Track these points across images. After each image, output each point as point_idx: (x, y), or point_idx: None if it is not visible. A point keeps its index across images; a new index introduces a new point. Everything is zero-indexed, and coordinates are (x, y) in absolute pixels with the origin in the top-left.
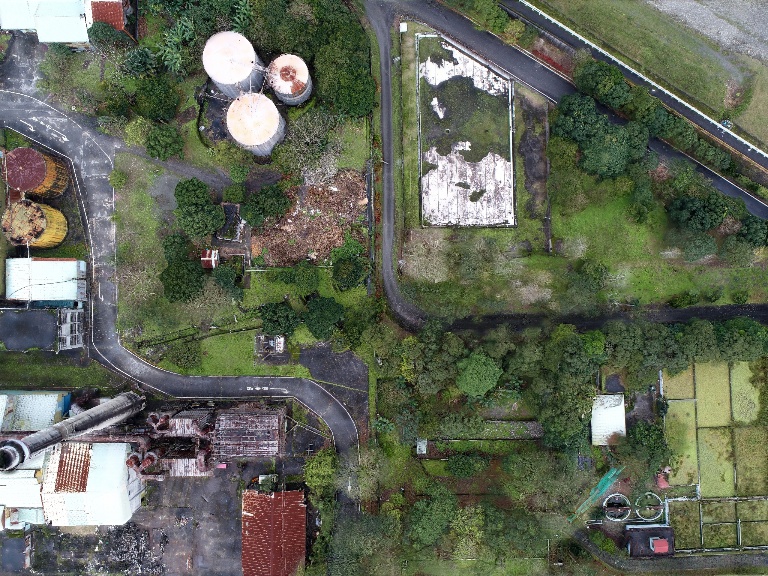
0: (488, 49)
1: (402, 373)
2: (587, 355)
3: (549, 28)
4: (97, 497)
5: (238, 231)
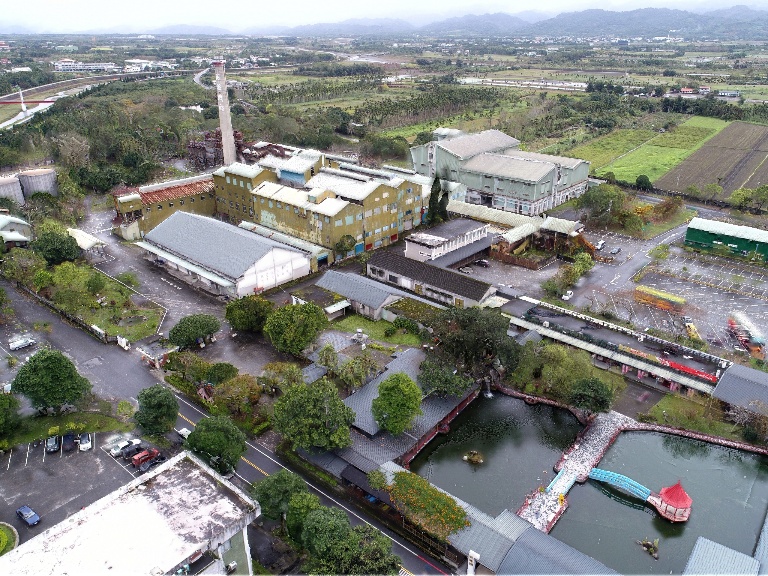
0: None
1: None
2: None
3: None
4: None
5: None
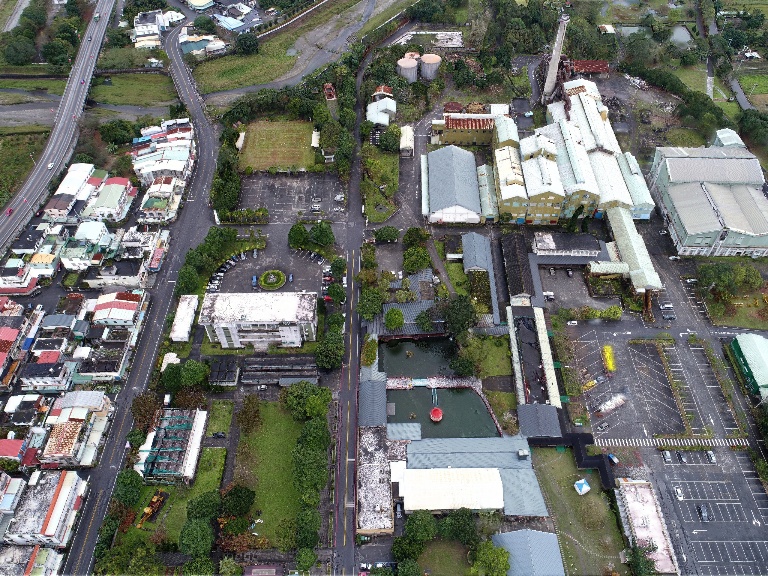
0: None
1: None
2: None
3: None
4: (585, 83)
5: None
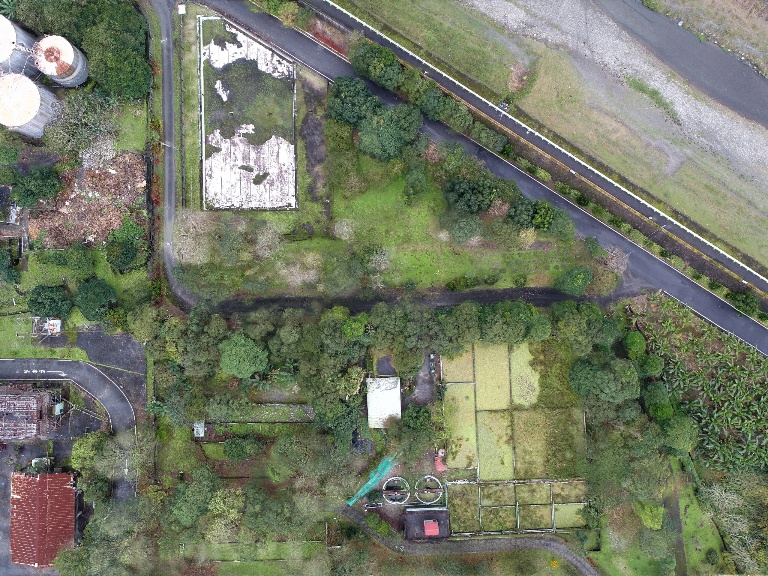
0: (270, 32)
1: (170, 355)
2: (345, 336)
3: (327, 10)
4: None
5: (13, 213)
